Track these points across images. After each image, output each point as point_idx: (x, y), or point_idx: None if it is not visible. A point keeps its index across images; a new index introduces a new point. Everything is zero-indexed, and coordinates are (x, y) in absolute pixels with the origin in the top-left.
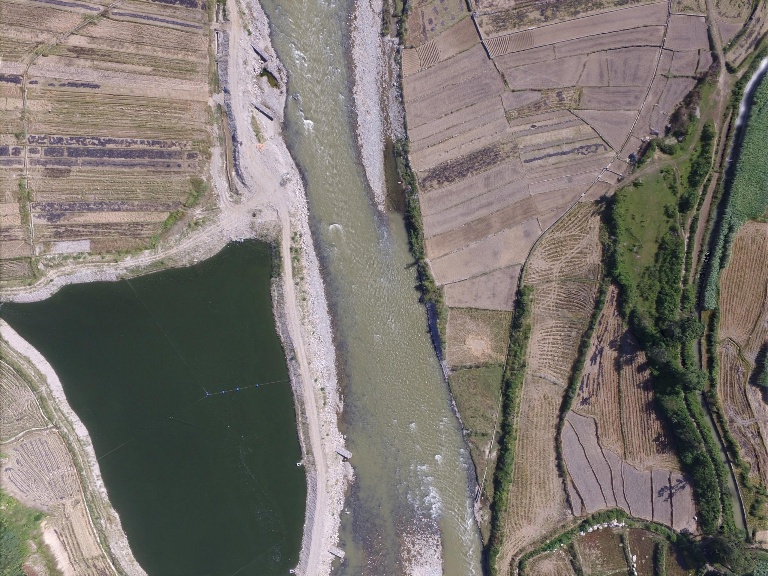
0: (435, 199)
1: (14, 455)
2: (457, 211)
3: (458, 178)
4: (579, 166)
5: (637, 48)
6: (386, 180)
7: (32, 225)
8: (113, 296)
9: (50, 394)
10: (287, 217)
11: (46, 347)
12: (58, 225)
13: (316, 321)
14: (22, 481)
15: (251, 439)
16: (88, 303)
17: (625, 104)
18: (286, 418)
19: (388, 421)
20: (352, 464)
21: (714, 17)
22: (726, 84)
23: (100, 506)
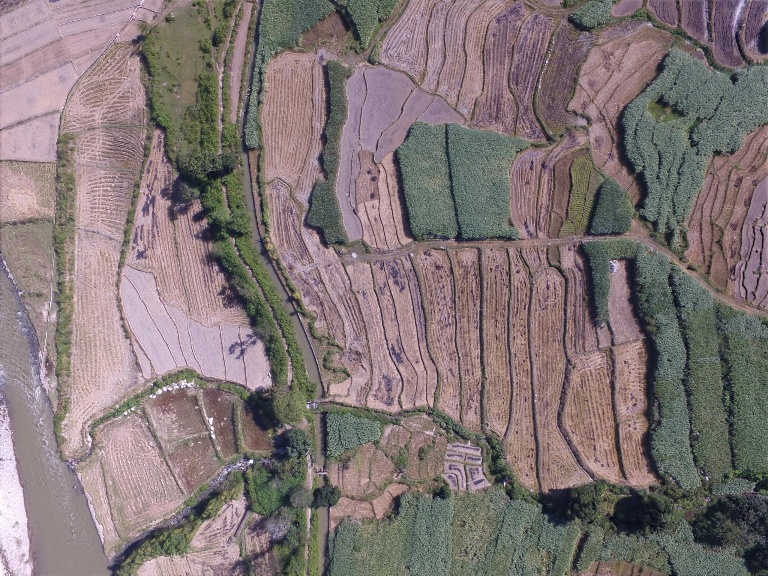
0: None
1: None
2: None
3: None
4: (110, 4)
5: None
6: None
7: None
8: None
9: None
10: None
11: None
12: None
13: None
14: None
15: None
16: None
17: None
18: None
19: None
20: None
21: None
22: None
23: None
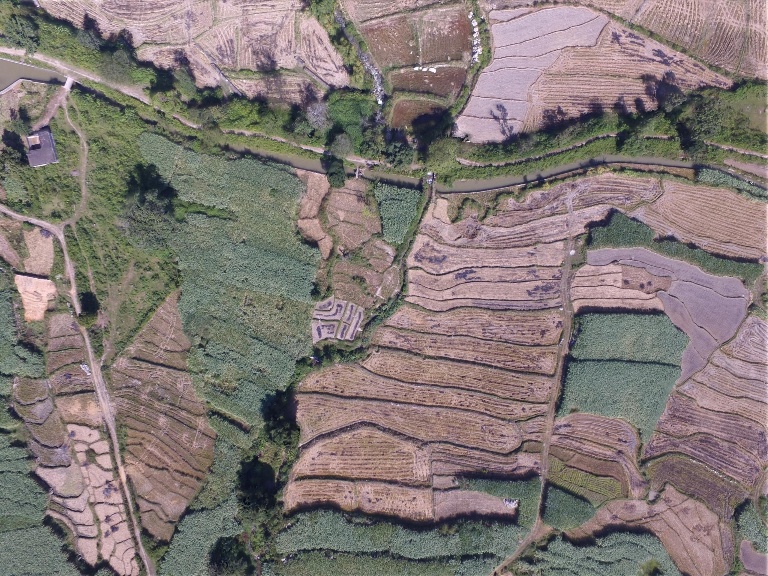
0: None
1: None
2: None
3: None
4: None
5: None
6: None
7: None
8: None
9: None
10: None
11: None
12: None
13: None
14: None
15: None
16: None
17: None
18: None
19: None
20: None
21: None
22: None
23: None
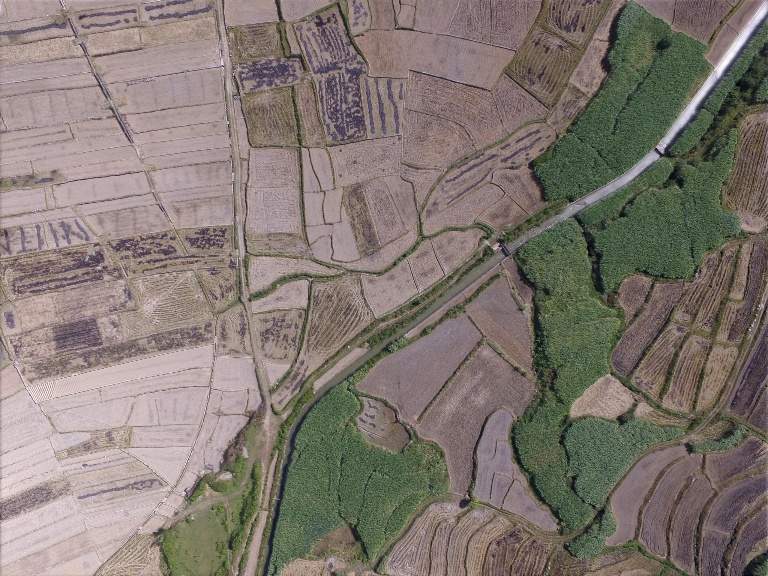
0: None
1: None
2: (12, 546)
3: (11, 516)
4: (134, 501)
5: (186, 388)
6: None
7: None
8: None
9: None
10: None
11: None
12: None
13: None
14: None
15: None
16: None
17: (177, 441)
18: None
19: None
20: None
21: (260, 359)
22: (272, 425)
23: None
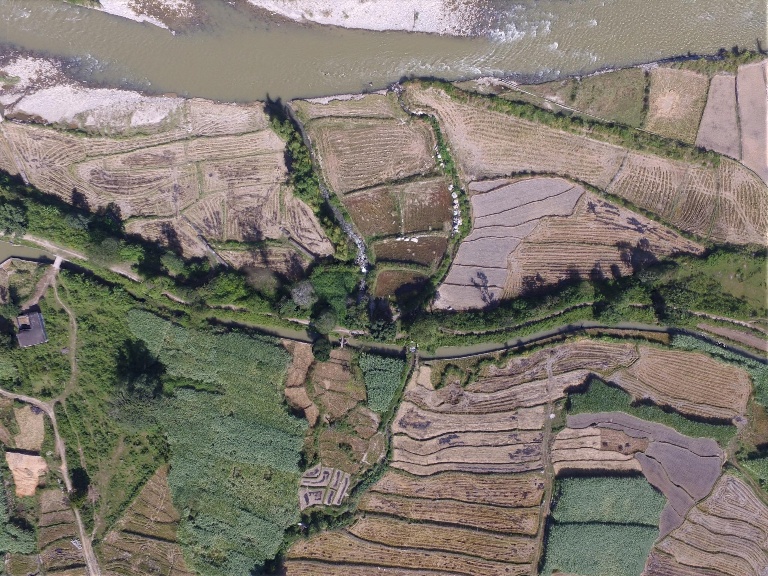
0: None
1: None
2: None
3: None
4: None
5: None
6: None
7: None
8: None
9: None
10: None
11: None
12: None
13: None
14: None
15: None
16: None
17: None
18: None
19: None
20: None
21: None
22: None
23: None
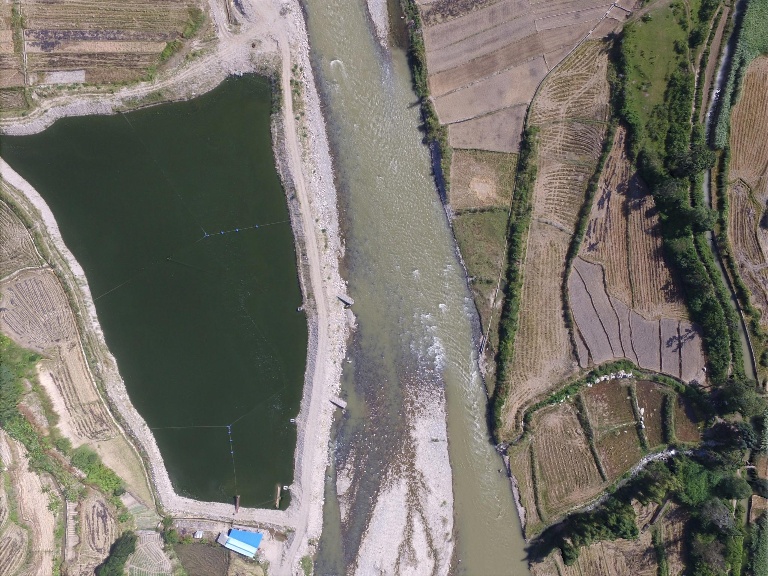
0: (439, 34)
1: (8, 295)
2: (461, 47)
3: (462, 12)
4: (587, 1)
5: None
6: (389, 15)
7: (25, 53)
8: (109, 130)
9: (45, 230)
10: (287, 48)
11: (41, 182)
12: (52, 54)
13: (317, 160)
14: (17, 322)
15: (251, 283)
16: (83, 137)
17: None
18: (286, 262)
19: (391, 267)
20: (354, 311)
21: None
22: None
23: (96, 348)
